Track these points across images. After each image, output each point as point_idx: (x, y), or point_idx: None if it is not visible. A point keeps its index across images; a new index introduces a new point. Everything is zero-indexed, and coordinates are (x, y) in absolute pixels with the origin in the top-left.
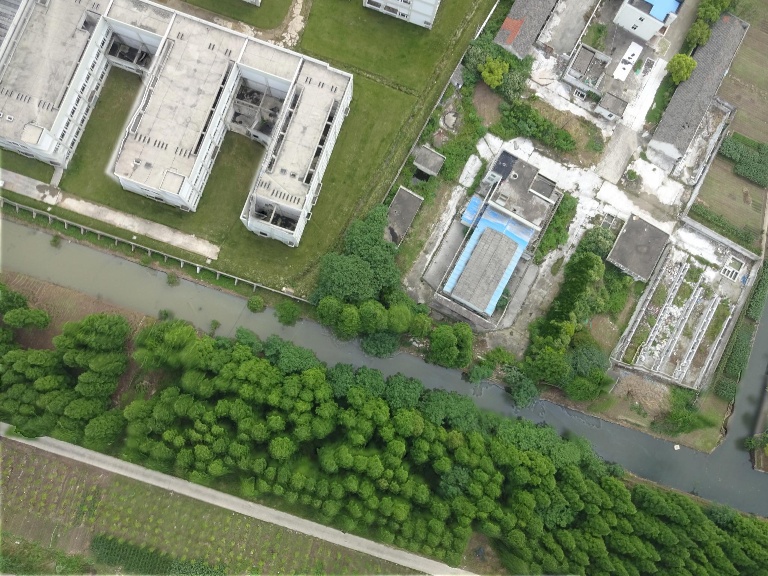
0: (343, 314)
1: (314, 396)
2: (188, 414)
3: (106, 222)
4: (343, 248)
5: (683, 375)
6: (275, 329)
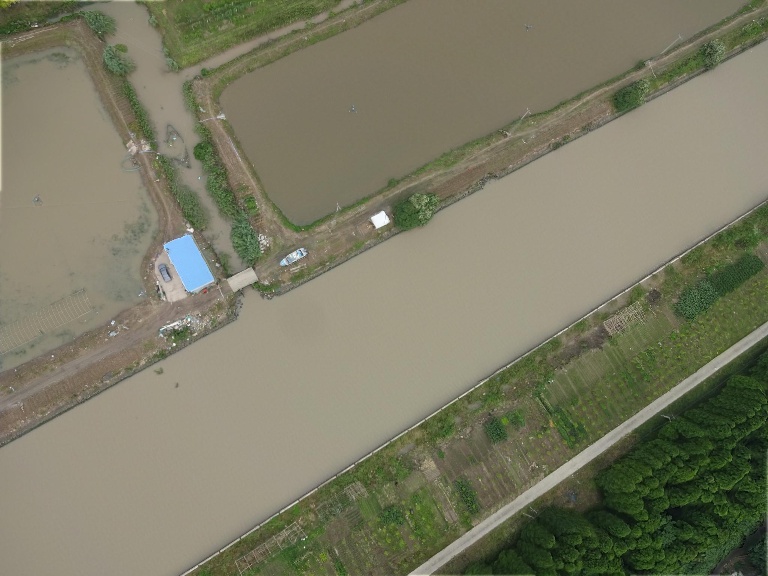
0: None
1: None
2: None
3: None
4: None
5: None
6: None
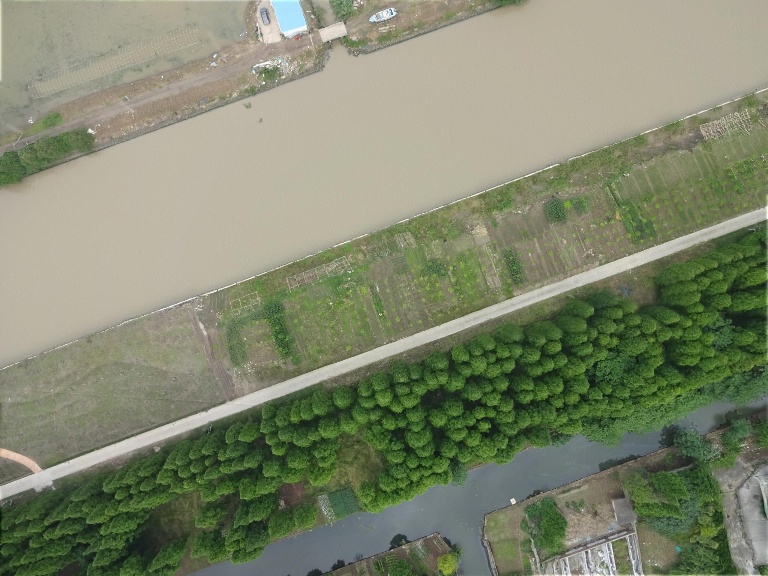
0: None
1: None
2: None
3: None
4: None
5: (555, 567)
6: None
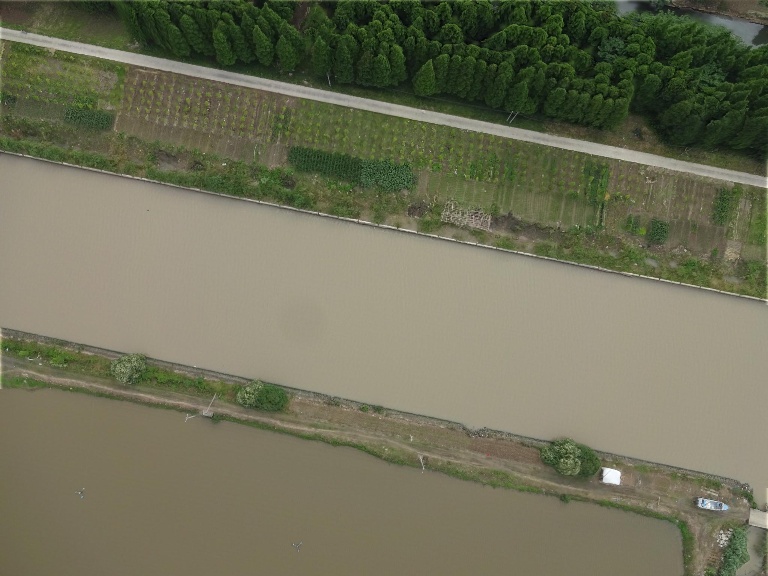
0: None
1: None
2: (367, 7)
3: None
4: None
5: None
6: None
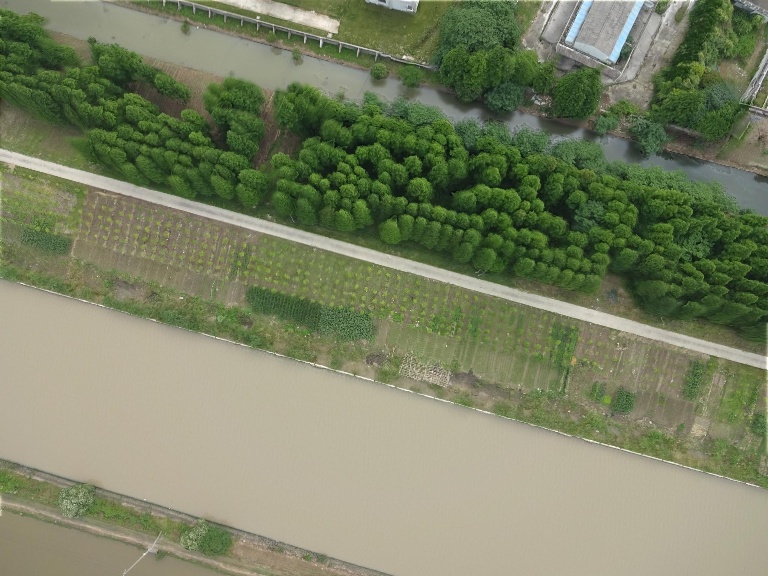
0: (469, 63)
1: (447, 139)
2: (331, 157)
3: (230, 5)
4: (463, 5)
5: None
6: (400, 90)
